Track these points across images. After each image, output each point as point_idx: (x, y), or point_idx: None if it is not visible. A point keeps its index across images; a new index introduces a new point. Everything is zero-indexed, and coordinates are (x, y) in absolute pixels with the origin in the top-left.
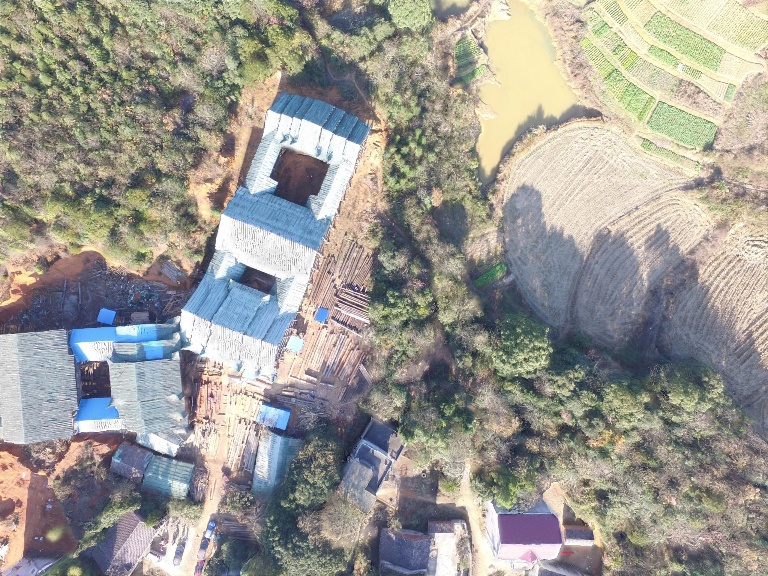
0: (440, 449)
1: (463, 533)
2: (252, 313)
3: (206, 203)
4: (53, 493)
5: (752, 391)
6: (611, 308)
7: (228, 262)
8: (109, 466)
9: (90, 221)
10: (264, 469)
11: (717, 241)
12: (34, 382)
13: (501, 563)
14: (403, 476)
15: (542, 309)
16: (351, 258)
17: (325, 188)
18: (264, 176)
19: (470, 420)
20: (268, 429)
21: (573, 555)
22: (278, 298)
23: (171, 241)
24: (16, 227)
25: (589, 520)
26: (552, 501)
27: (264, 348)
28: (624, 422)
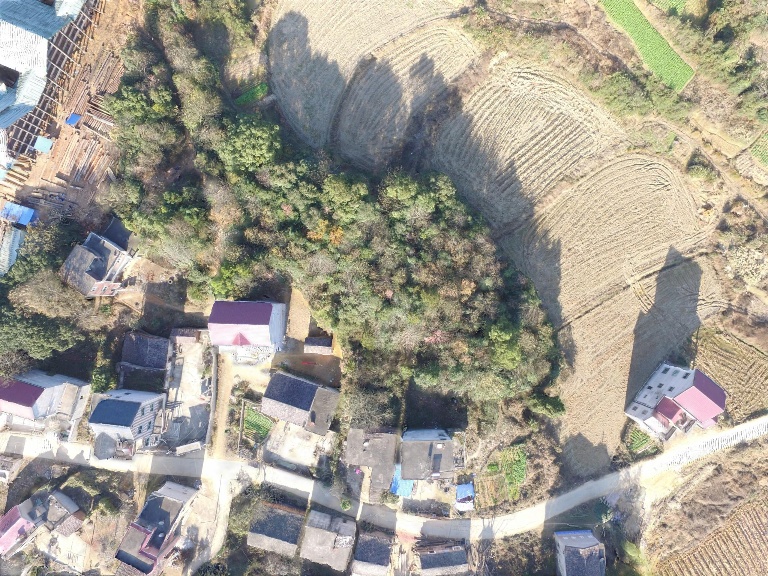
0: (160, 235)
1: None
2: None
3: None
4: None
5: (512, 219)
6: (373, 133)
7: None
8: None
9: None
10: (5, 263)
11: (481, 70)
12: None
13: (247, 373)
14: (149, 281)
15: (303, 130)
16: (106, 67)
17: None
18: None
19: (190, 207)
20: (11, 224)
21: (317, 367)
22: (16, 90)
23: None
24: None
25: (328, 328)
26: (299, 313)
27: None
28: (340, 212)
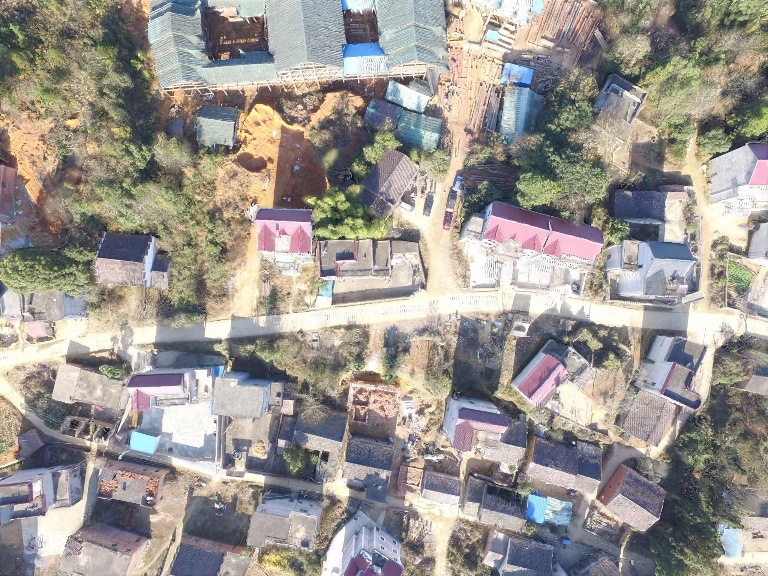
0: (693, 81)
1: (689, 200)
2: None
3: None
4: (303, 152)
5: None
6: None
7: None
8: None
9: None
10: (511, 121)
11: None
12: (312, 6)
13: (725, 229)
14: (634, 141)
15: None
16: None
17: None
18: None
19: None
20: (514, 84)
21: None
22: None
23: None
24: None
25: None
26: None
27: None
28: None
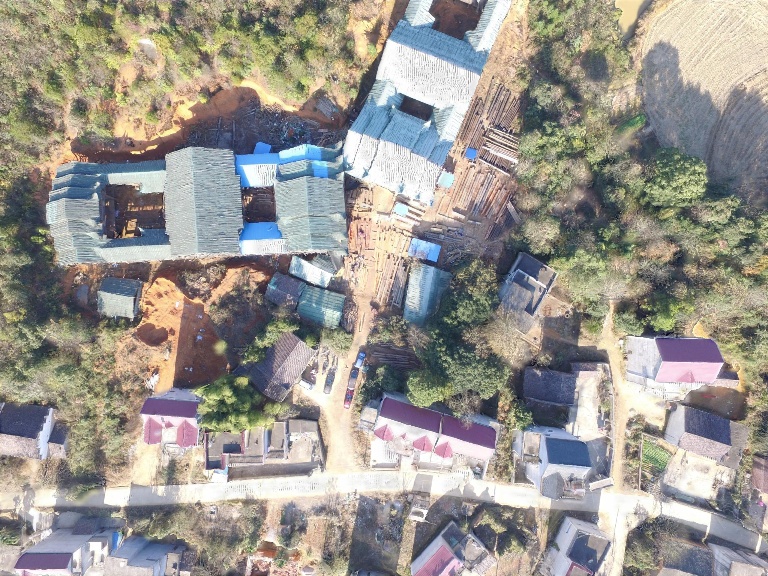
0: (599, 272)
1: (604, 376)
2: (416, 135)
3: (363, 40)
4: (205, 323)
5: None
6: (747, 163)
7: (389, 91)
8: (264, 294)
9: (259, 46)
10: (416, 300)
11: None
12: (206, 195)
13: (642, 407)
14: (547, 316)
15: None
16: (499, 101)
17: (483, 22)
18: (424, 10)
19: (629, 244)
20: (420, 261)
21: (714, 400)
22: (437, 127)
23: (331, 73)
24: (188, 50)
25: (734, 361)
26: None
27: (428, 169)
28: None
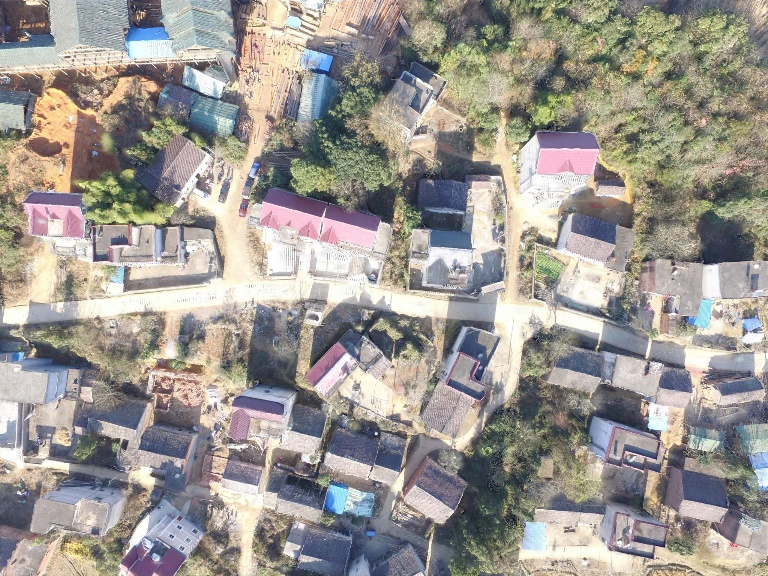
0: (481, 68)
1: (498, 190)
2: None
3: None
4: (100, 137)
5: None
6: None
7: None
8: (156, 103)
9: None
10: (308, 108)
11: None
12: None
13: (535, 220)
14: (441, 130)
15: None
16: None
17: None
18: None
19: (510, 41)
20: (312, 70)
21: (604, 211)
22: None
23: None
24: None
25: (620, 169)
26: None
27: None
28: (657, 43)
